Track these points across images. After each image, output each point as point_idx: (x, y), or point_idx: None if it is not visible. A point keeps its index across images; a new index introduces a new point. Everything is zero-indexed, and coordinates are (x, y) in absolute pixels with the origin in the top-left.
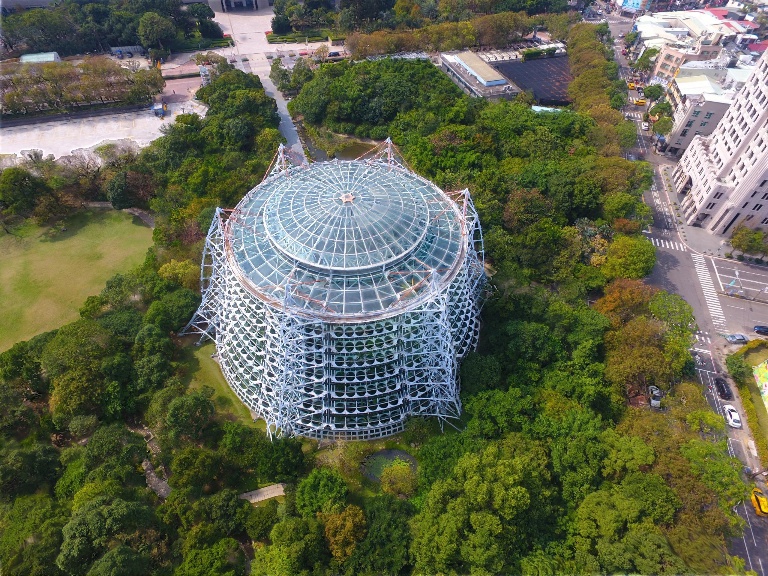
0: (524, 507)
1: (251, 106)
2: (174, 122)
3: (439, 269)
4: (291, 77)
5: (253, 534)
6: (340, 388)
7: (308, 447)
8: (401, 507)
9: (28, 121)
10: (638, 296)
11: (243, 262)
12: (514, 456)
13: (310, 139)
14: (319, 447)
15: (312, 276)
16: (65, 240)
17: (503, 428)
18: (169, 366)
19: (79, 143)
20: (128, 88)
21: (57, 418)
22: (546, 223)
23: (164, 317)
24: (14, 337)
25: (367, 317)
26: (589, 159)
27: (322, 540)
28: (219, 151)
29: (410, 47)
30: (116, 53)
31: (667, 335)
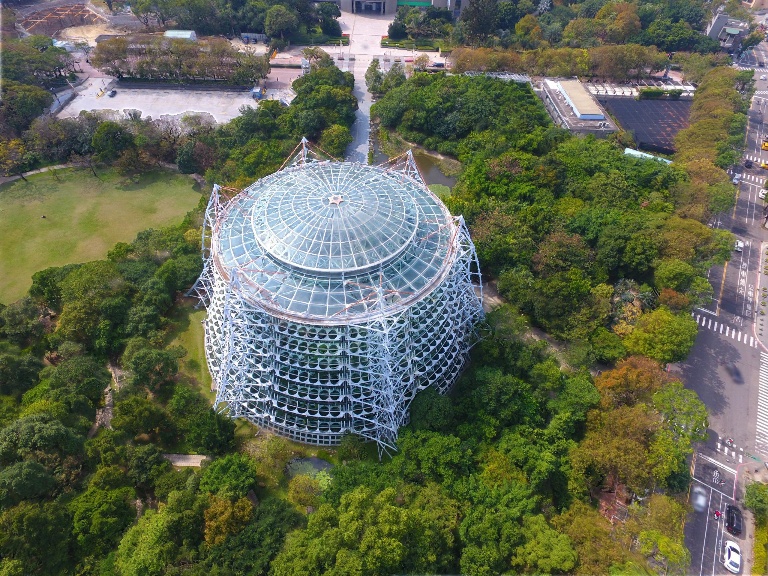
0: (390, 562)
1: (330, 101)
2: (257, 105)
3: (402, 291)
4: (384, 81)
5: (158, 493)
6: (284, 383)
7: (247, 431)
8: (290, 517)
9: (151, 86)
10: (644, 380)
11: (224, 239)
12: (424, 508)
13: (379, 142)
14: (256, 434)
15: (276, 267)
16: (134, 191)
17: (425, 475)
18: (159, 320)
19: (182, 111)
20: (235, 69)
21: (52, 338)
22: (574, 274)
23: (171, 275)
24: (62, 263)
25: (308, 319)
26: (659, 216)
27: (202, 521)
28: (286, 138)
29: (514, 68)
30: (244, 38)
31: (658, 433)
